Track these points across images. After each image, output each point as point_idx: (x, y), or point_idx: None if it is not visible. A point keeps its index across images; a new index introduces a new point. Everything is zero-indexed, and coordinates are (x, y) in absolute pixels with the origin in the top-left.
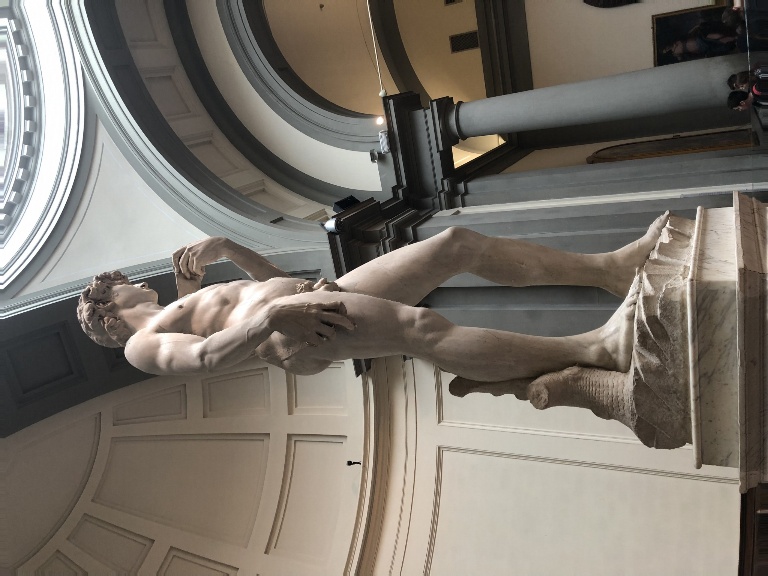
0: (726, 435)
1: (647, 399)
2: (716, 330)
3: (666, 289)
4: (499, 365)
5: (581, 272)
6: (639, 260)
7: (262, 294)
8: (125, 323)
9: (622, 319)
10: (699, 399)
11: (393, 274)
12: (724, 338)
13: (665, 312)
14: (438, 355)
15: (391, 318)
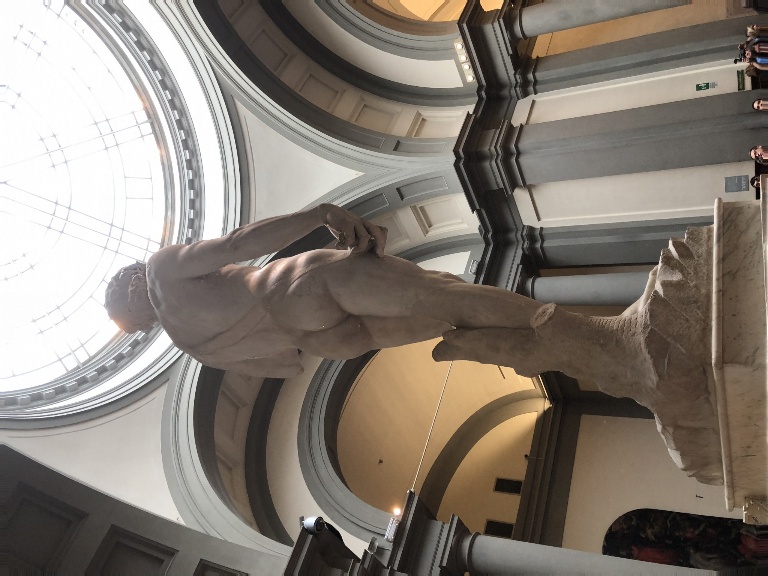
0: (752, 328)
1: (664, 311)
2: (741, 235)
3: None
4: (509, 302)
5: None
6: None
7: None
8: None
9: None
10: (722, 293)
11: None
12: (749, 241)
13: (692, 235)
14: (451, 288)
15: (418, 267)
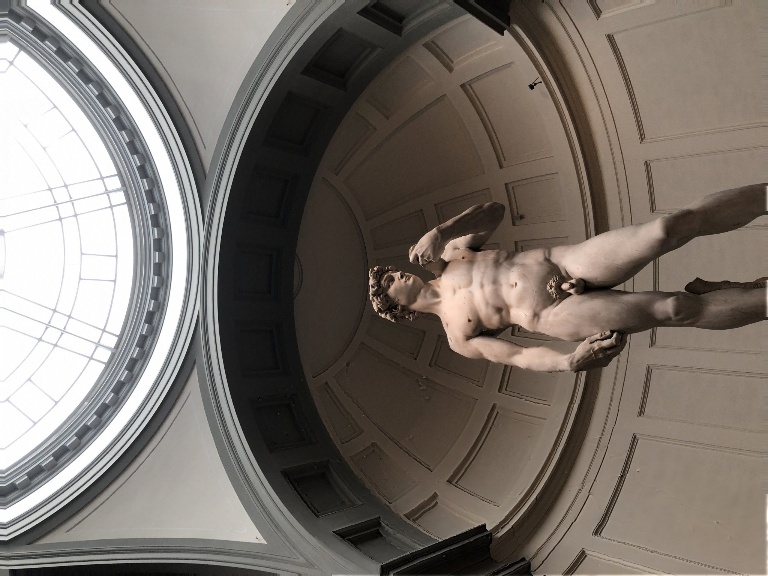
0: None
1: None
2: None
3: None
4: None
5: None
6: None
7: (529, 309)
8: (420, 312)
9: None
10: None
11: (625, 267)
12: None
13: None
14: None
15: (651, 320)
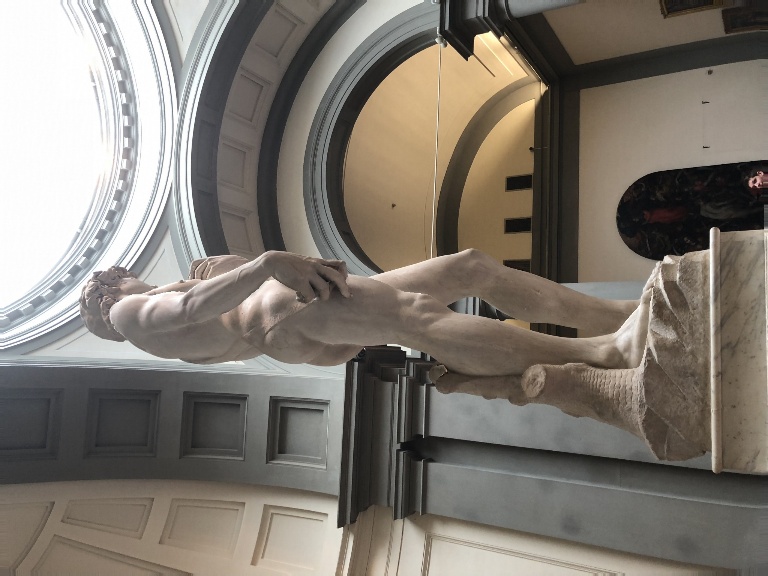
0: (753, 426)
1: (659, 384)
2: (742, 289)
3: None
4: (495, 350)
5: (600, 313)
6: None
7: None
8: None
9: (638, 311)
10: (720, 376)
11: (403, 279)
12: (751, 298)
13: (685, 275)
14: (431, 334)
15: (390, 295)
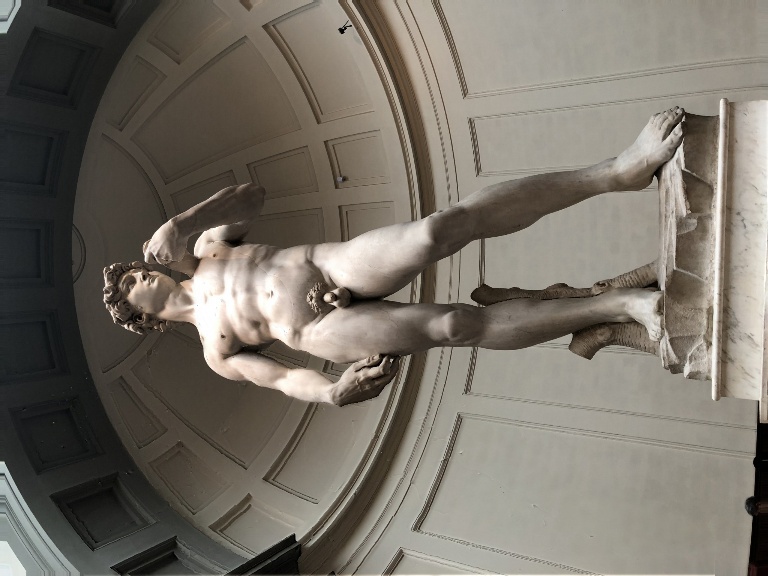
0: None
1: None
2: None
3: (691, 373)
4: None
5: None
6: (649, 173)
7: (287, 325)
8: (172, 322)
9: None
10: None
11: (393, 276)
12: None
13: None
14: None
15: (426, 341)
